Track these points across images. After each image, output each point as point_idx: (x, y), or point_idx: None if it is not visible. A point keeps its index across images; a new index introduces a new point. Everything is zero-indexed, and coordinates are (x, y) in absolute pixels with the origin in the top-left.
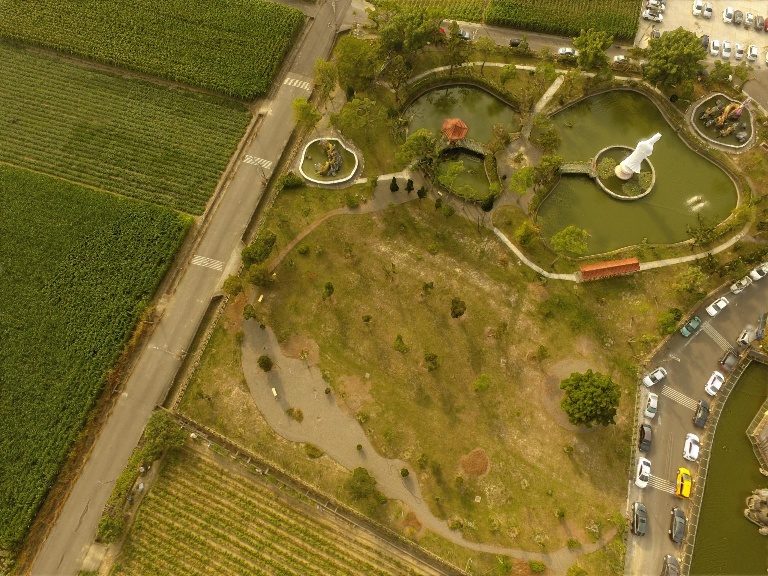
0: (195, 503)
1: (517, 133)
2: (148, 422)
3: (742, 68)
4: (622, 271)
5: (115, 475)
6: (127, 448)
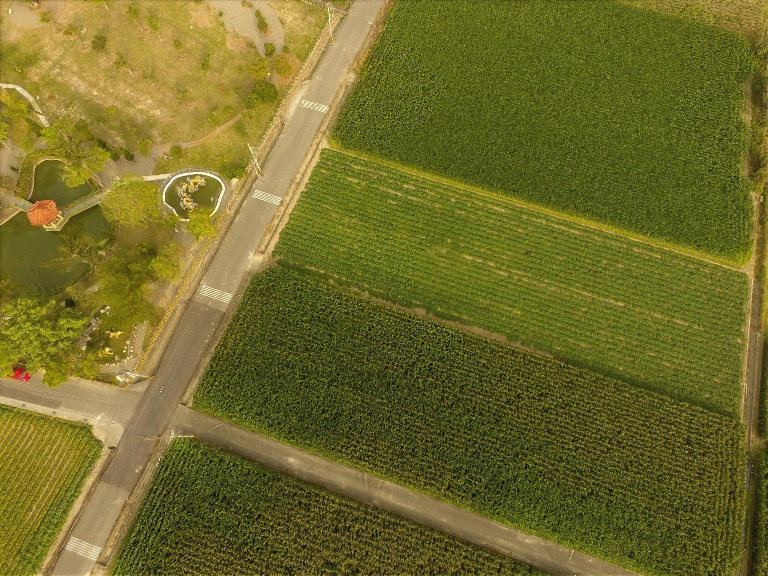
0: None
1: None
2: (348, 1)
3: None
4: None
5: None
6: None
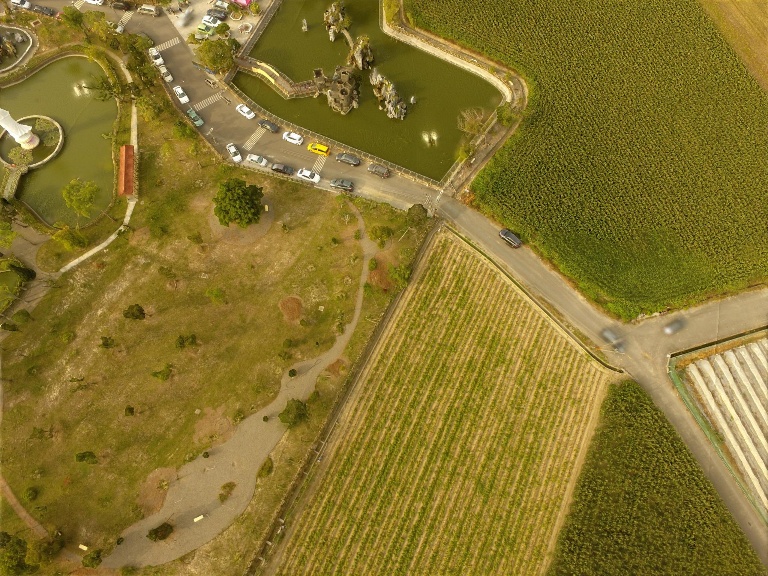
0: None
1: None
2: None
3: None
4: (131, 160)
5: None
6: None
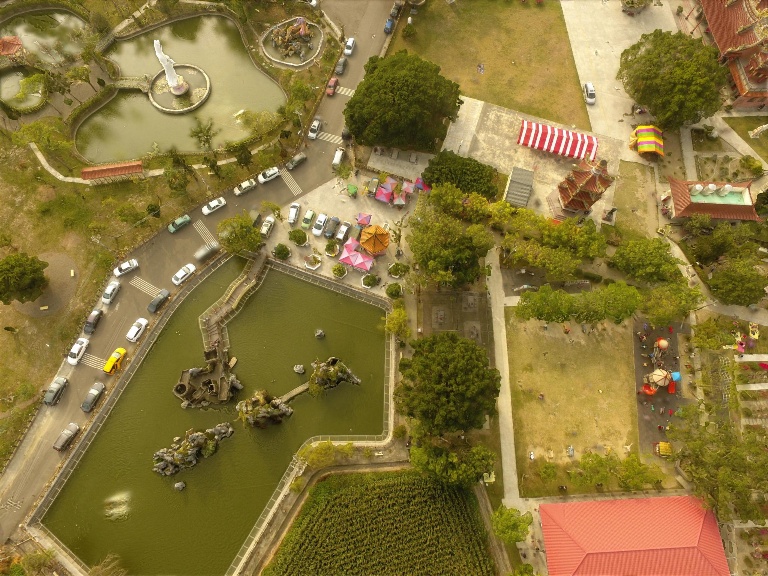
0: None
1: None
2: None
3: None
4: (122, 172)
5: None
6: None
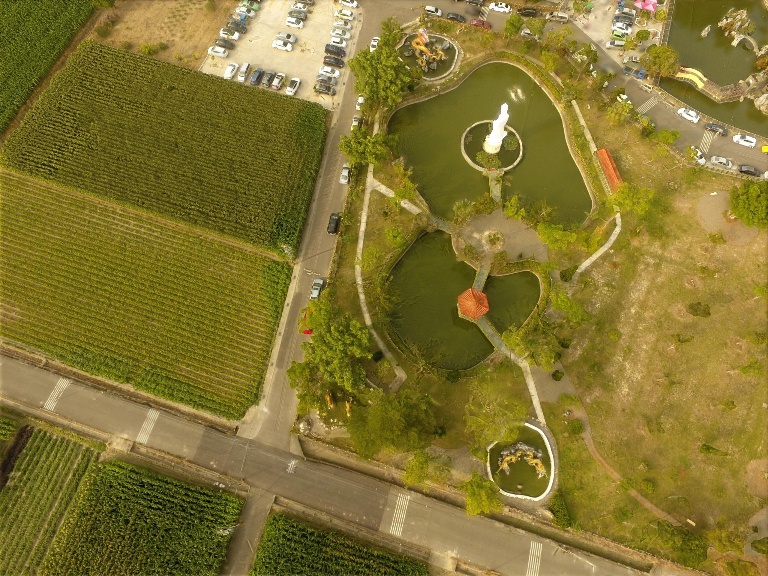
0: None
1: (455, 238)
2: None
3: (387, 26)
4: None
5: None
6: None
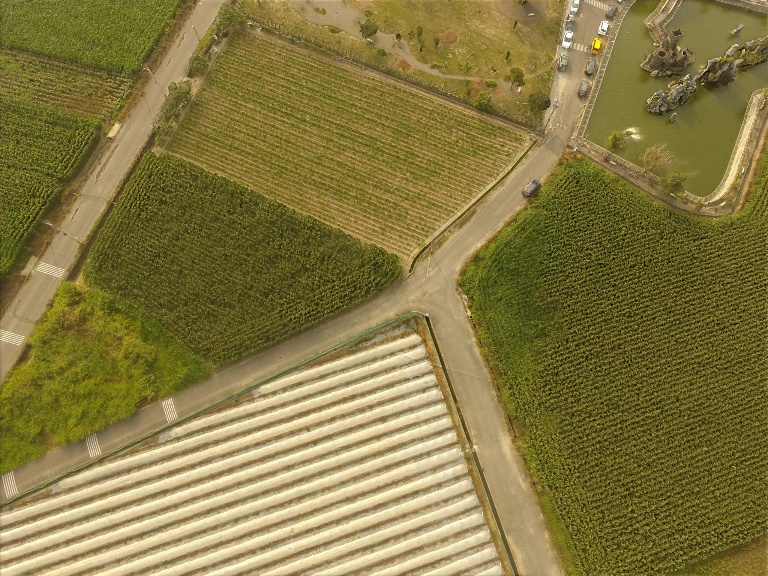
0: (253, 59)
1: None
2: (218, 11)
3: None
4: None
5: (197, 43)
6: (204, 30)
